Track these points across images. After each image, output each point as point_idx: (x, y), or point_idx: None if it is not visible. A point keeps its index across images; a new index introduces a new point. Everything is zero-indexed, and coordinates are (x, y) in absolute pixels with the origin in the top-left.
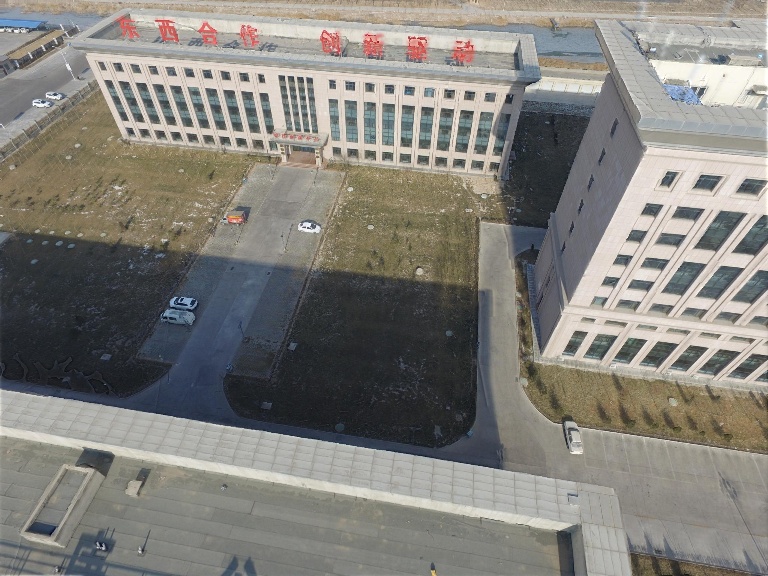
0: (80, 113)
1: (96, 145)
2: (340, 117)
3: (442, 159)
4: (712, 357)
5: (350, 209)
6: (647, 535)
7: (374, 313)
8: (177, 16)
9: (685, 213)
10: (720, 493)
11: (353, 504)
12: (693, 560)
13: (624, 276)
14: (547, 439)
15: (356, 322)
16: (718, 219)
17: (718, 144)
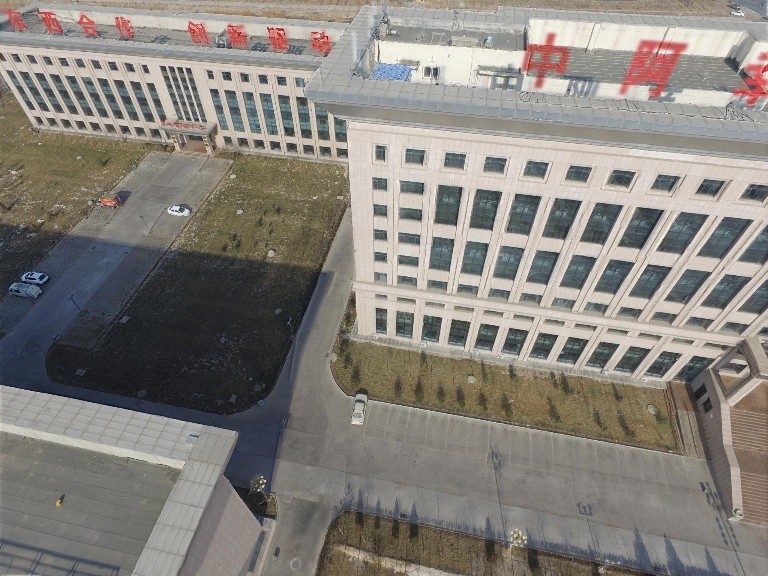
0: (3, 103)
1: (8, 133)
2: (224, 107)
3: (326, 149)
4: (509, 336)
5: (226, 195)
6: (398, 500)
7: (214, 291)
8: (81, 10)
9: (413, 188)
10: (484, 465)
11: (20, 442)
12: (434, 525)
13: (389, 251)
14: (335, 410)
15: (193, 299)
16: (444, 194)
17: (392, 117)
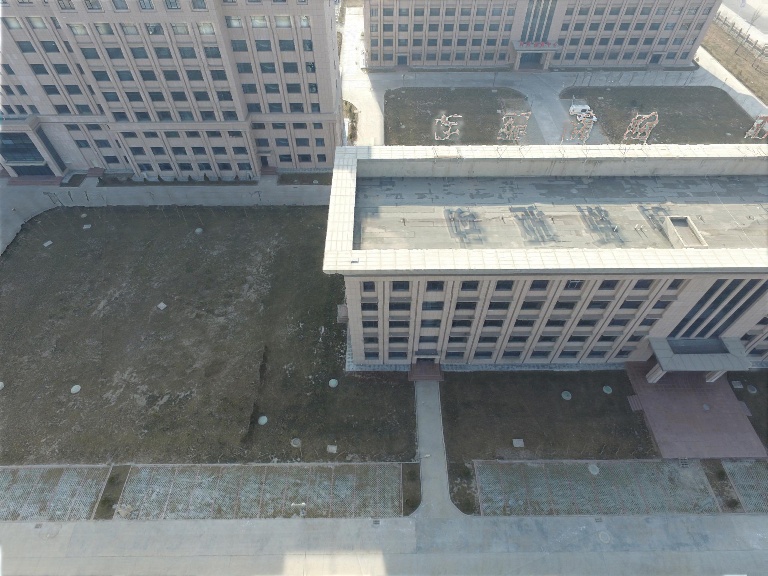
0: None
1: None
2: None
3: None
4: None
5: None
6: None
7: None
8: None
9: None
10: None
11: None
12: None
13: None
14: (347, 95)
15: (467, 126)
16: None
17: None
